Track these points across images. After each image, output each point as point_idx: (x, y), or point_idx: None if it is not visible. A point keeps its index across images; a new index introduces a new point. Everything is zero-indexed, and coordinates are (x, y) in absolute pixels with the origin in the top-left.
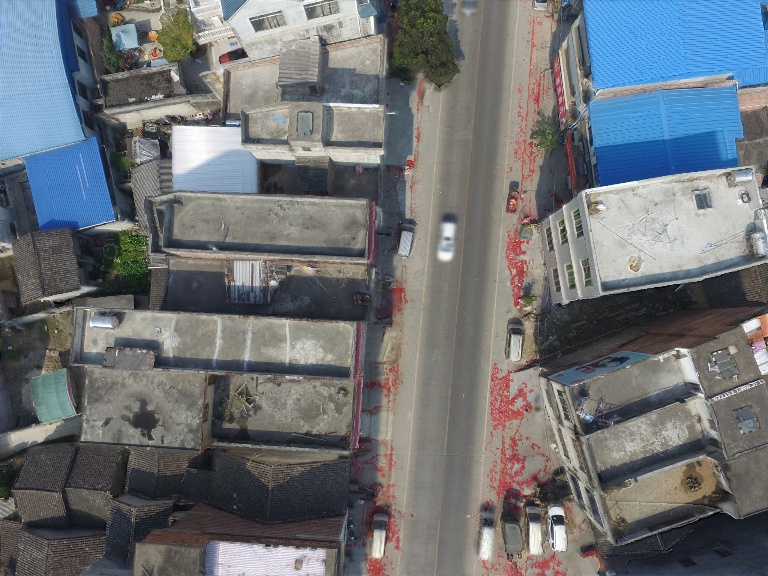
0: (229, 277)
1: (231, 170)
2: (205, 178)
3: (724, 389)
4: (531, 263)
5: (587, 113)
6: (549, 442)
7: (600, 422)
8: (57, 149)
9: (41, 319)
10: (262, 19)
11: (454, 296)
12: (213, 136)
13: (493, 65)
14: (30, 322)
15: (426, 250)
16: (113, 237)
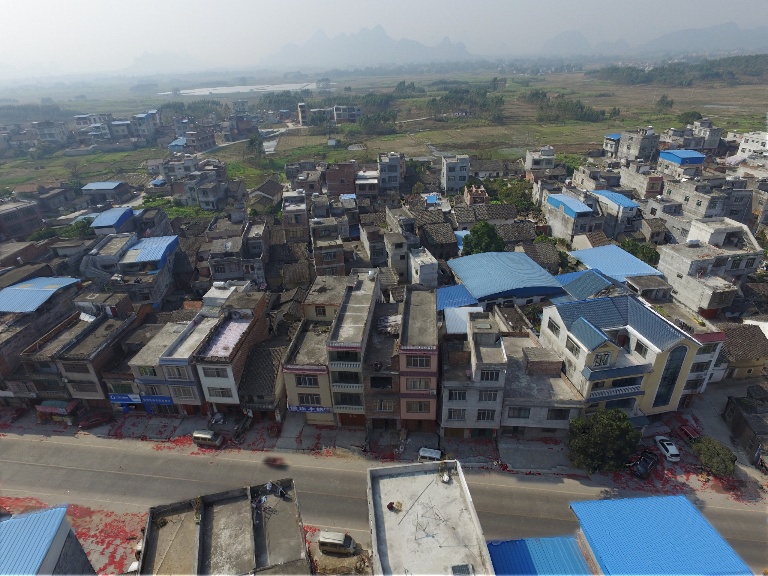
0: (393, 315)
1: (461, 328)
2: (454, 319)
3: None
4: None
5: None
6: None
7: None
8: (469, 292)
9: None
10: (553, 324)
11: None
12: None
13: None
14: None
15: None
16: None
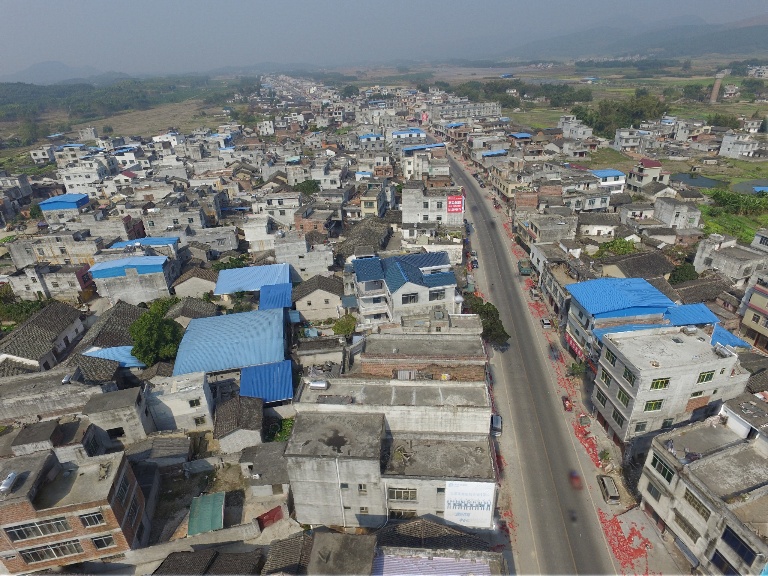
0: None
1: None
2: None
3: (764, 422)
4: (597, 437)
5: (594, 338)
6: (685, 575)
7: (691, 456)
8: (265, 365)
9: (205, 471)
10: (408, 297)
11: (544, 460)
12: None
13: (529, 348)
14: (195, 473)
15: (513, 433)
16: (278, 421)
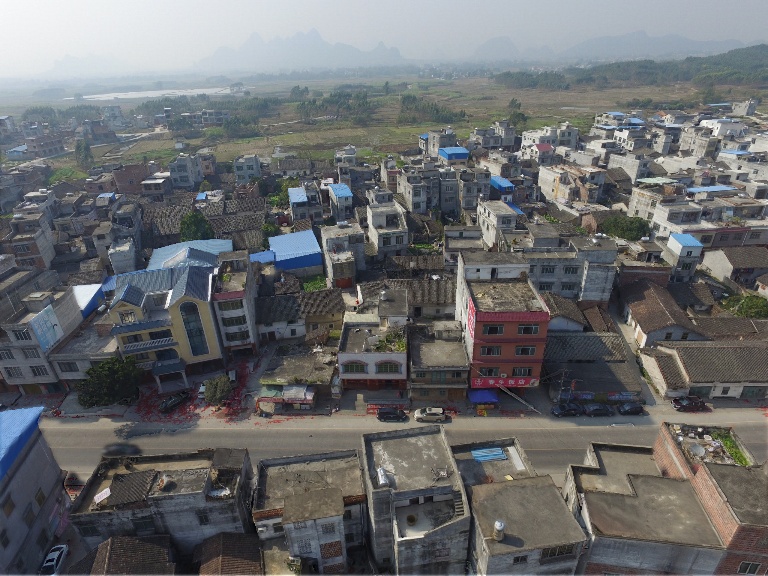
0: None
1: None
2: None
3: None
4: None
5: None
6: None
7: None
8: None
9: None
10: None
11: None
12: (89, 295)
13: None
14: None
15: None
16: None
